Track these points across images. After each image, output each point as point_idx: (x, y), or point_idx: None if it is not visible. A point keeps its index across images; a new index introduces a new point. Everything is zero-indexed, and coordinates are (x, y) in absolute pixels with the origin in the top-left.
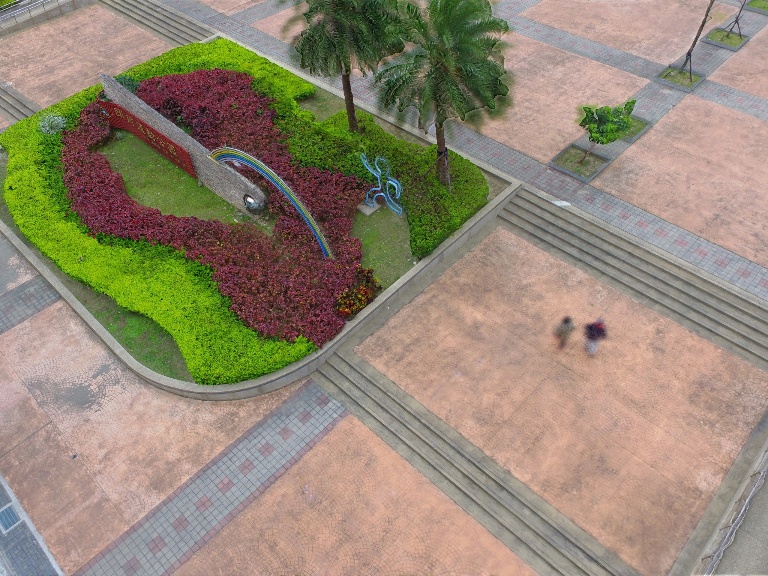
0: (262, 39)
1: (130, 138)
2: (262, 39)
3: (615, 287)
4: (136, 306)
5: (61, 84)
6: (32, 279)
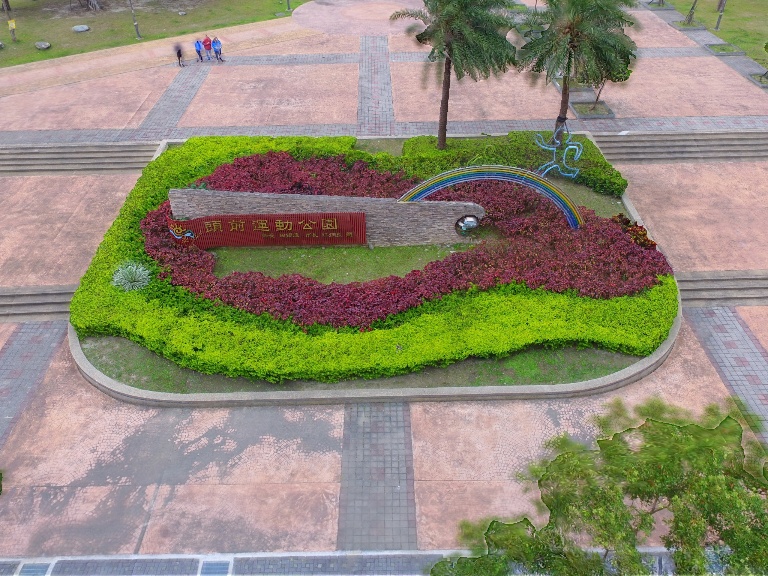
0: (213, 131)
1: (225, 254)
2: (213, 131)
3: (712, 162)
4: (520, 341)
5: (26, 257)
6: (346, 413)
